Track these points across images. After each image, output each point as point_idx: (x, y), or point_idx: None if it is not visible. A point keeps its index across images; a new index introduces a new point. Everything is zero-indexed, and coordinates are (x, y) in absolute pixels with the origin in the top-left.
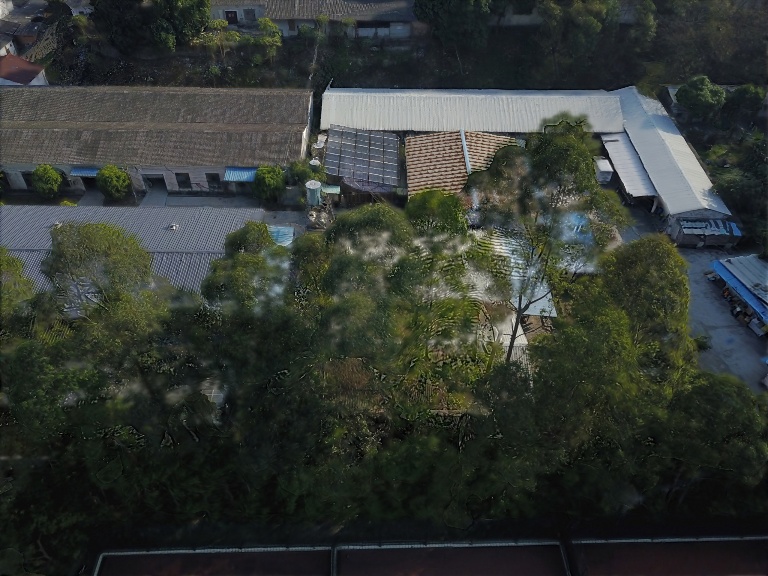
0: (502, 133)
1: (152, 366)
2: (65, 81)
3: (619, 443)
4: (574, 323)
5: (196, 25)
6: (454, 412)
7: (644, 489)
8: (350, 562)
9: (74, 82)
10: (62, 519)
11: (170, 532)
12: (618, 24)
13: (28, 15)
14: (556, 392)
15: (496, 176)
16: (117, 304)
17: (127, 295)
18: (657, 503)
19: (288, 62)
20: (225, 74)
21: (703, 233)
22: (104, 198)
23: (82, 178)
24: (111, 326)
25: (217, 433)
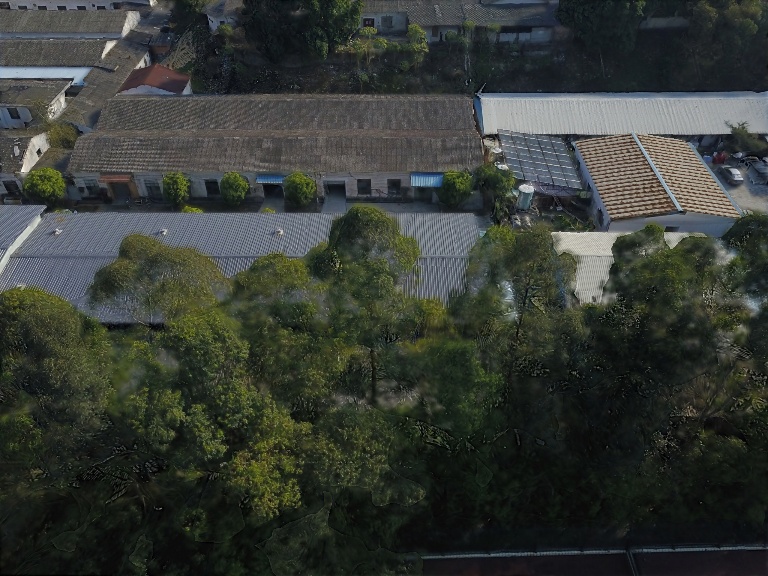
0: (665, 136)
1: (525, 369)
2: (210, 90)
3: None
4: None
5: (345, 33)
6: None
7: None
8: (649, 565)
9: (219, 91)
10: (392, 523)
11: (459, 536)
12: None
13: (156, 26)
14: None
15: None
16: (555, 307)
17: (565, 298)
18: None
19: (431, 68)
20: (371, 81)
21: None
22: (284, 205)
23: (264, 185)
24: (554, 329)
25: None
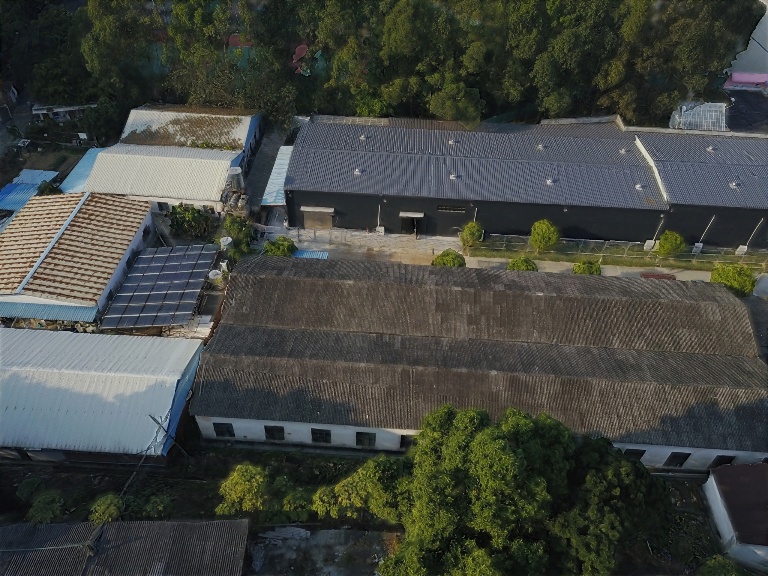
0: None
1: None
2: None
3: None
4: None
5: None
6: None
7: None
8: None
9: None
10: None
11: None
12: None
13: None
14: None
15: None
16: None
17: None
18: None
19: None
20: None
21: None
22: None
23: None
24: None
25: None
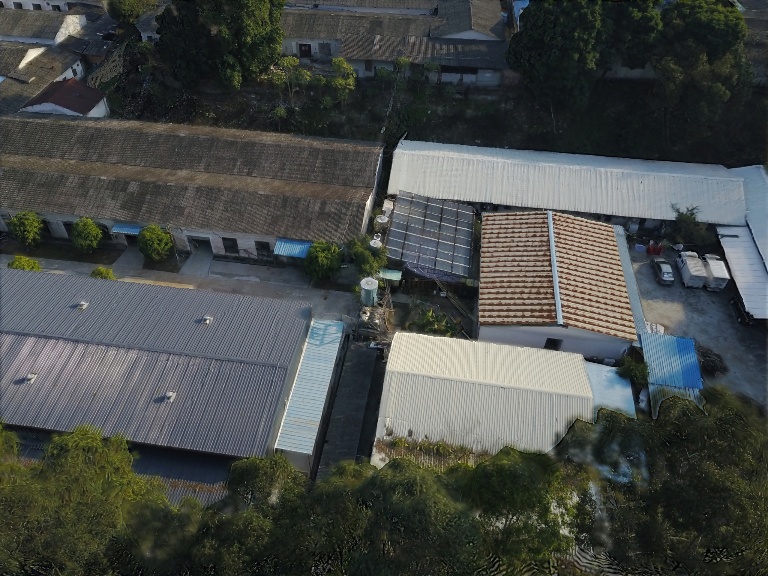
0: (596, 214)
1: None
2: (126, 110)
3: None
4: None
5: (265, 61)
6: None
7: None
8: None
9: (135, 112)
10: None
11: None
12: (750, 92)
13: (100, 31)
14: None
15: (614, 467)
16: None
17: (85, 568)
18: None
19: (361, 106)
20: (291, 115)
21: None
22: None
23: None
24: None
25: None
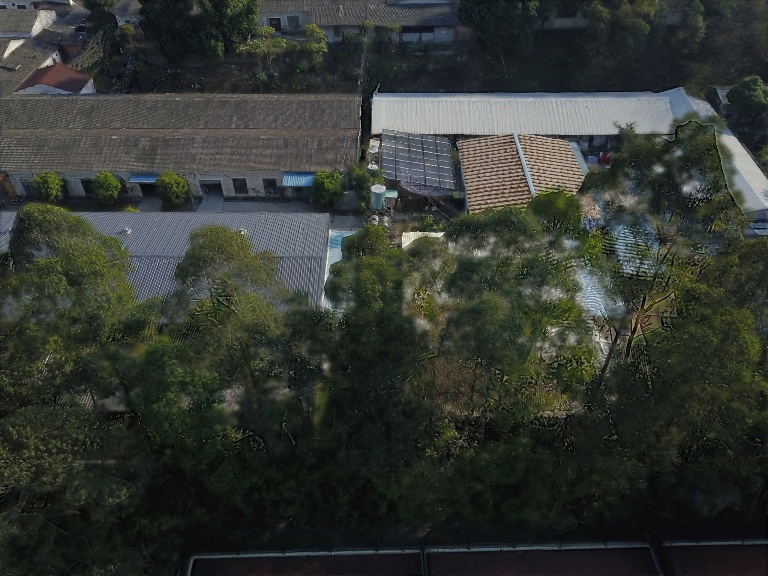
0: (553, 136)
1: (263, 369)
2: (113, 89)
3: (726, 444)
4: (695, 323)
5: (243, 32)
6: (559, 414)
7: (748, 491)
8: (441, 565)
9: (122, 90)
10: (162, 522)
11: (258, 535)
12: (666, 26)
13: (71, 25)
14: (676, 393)
15: (622, 177)
16: (247, 307)
17: (257, 298)
18: (751, 505)
19: (333, 68)
20: (271, 80)
21: (766, 234)
22: (161, 204)
23: (140, 185)
24: (243, 329)
25: (318, 436)
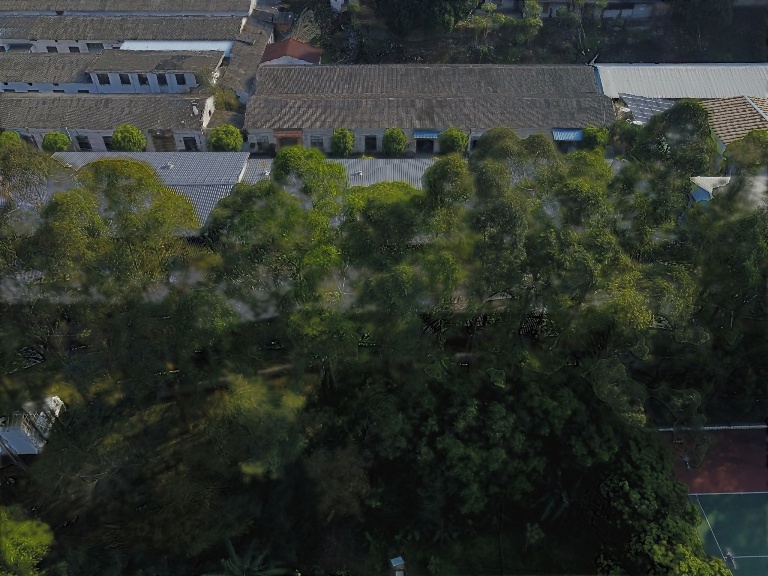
0: None
1: None
2: (338, 62)
3: None
4: None
5: (466, 9)
6: None
7: None
8: None
9: (347, 63)
10: None
11: (661, 415)
12: None
13: (273, 6)
14: None
15: None
16: None
17: None
18: None
19: (542, 42)
20: None
21: None
22: None
23: (417, 141)
24: None
25: None
